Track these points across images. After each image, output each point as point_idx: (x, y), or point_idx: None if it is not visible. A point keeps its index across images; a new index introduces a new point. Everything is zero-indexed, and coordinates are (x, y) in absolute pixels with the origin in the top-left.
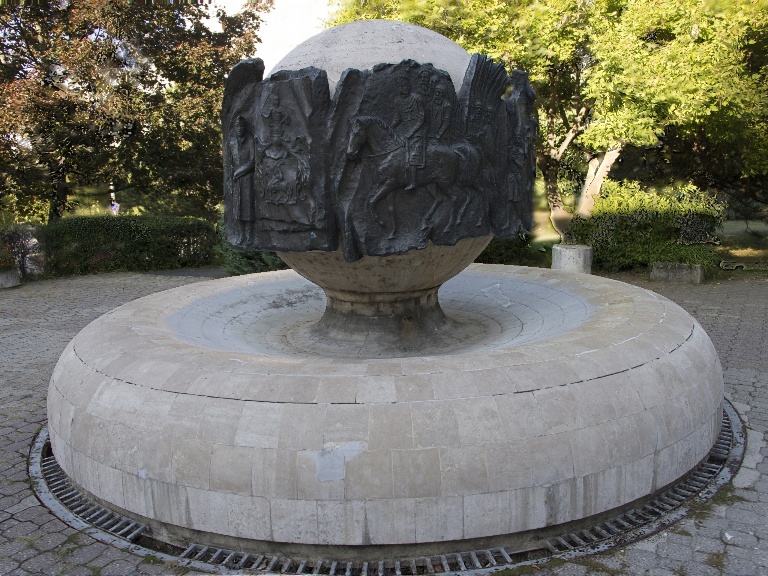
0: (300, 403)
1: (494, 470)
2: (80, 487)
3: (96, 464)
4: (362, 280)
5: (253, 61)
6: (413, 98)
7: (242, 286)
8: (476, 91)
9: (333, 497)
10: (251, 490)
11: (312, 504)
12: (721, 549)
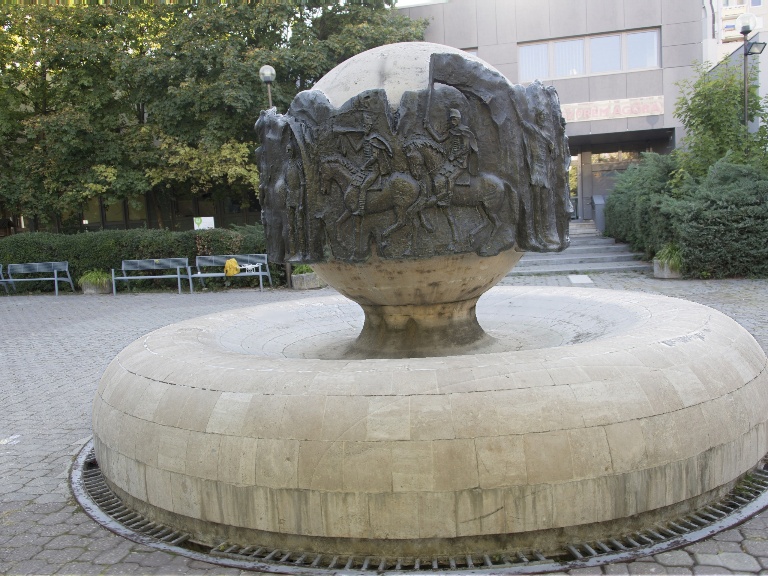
0: None
1: None
2: None
3: None
4: None
5: None
6: None
7: (643, 314)
8: None
9: None
10: None
11: None
12: None
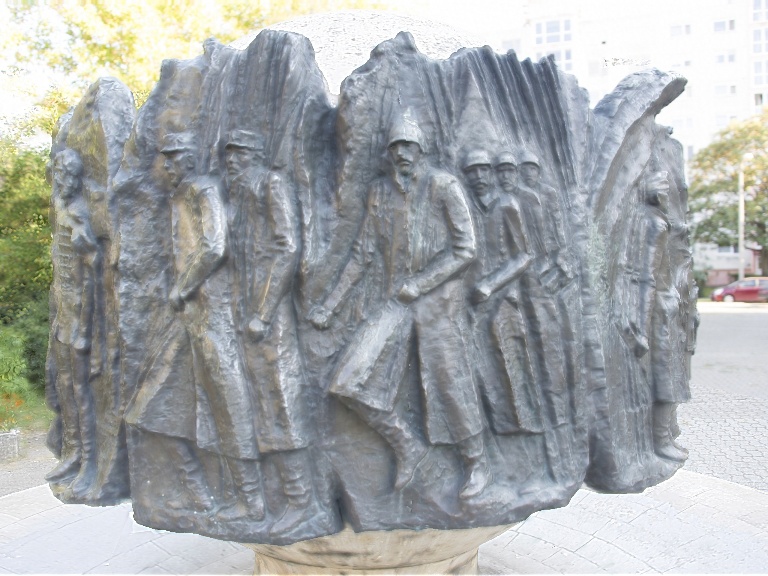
0: None
1: None
2: None
3: None
4: None
5: None
6: None
7: None
8: None
9: None
10: None
11: None
12: None
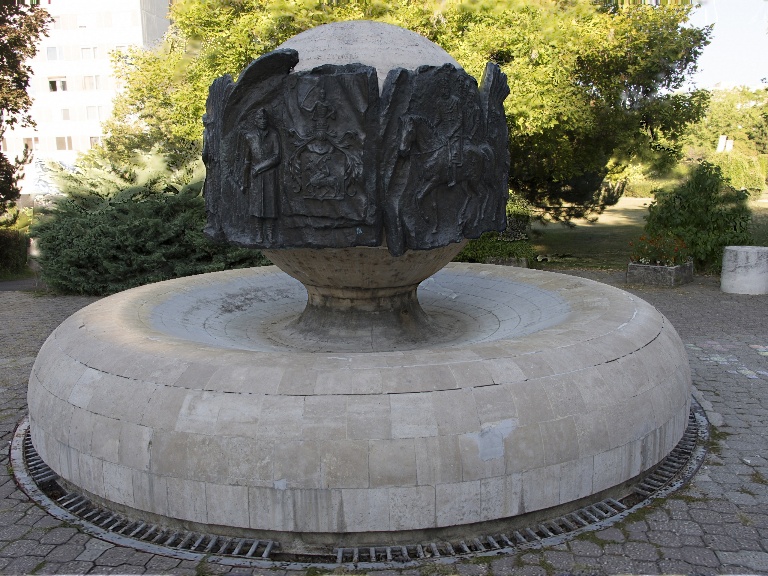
0: (445, 390)
1: (612, 430)
2: (150, 519)
3: (203, 486)
4: (376, 276)
5: (291, 52)
6: (454, 100)
7: (181, 292)
8: (492, 97)
9: (495, 474)
10: (416, 480)
11: (476, 484)
12: (753, 470)
